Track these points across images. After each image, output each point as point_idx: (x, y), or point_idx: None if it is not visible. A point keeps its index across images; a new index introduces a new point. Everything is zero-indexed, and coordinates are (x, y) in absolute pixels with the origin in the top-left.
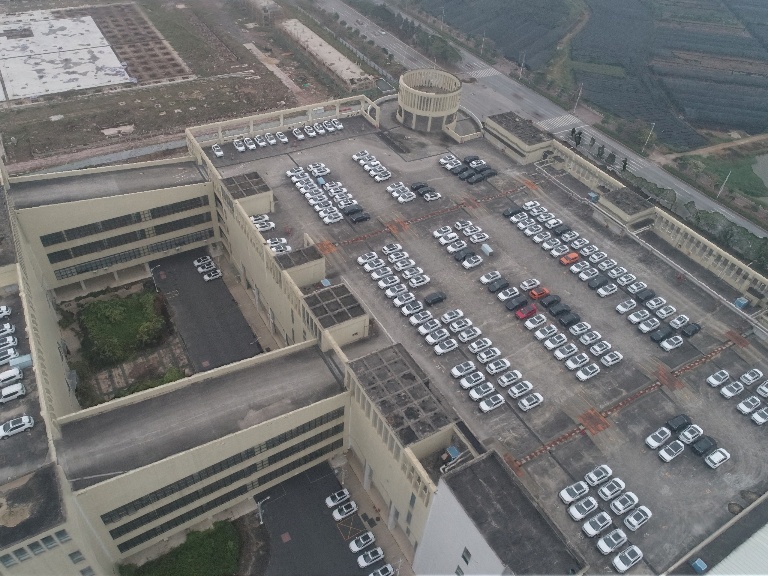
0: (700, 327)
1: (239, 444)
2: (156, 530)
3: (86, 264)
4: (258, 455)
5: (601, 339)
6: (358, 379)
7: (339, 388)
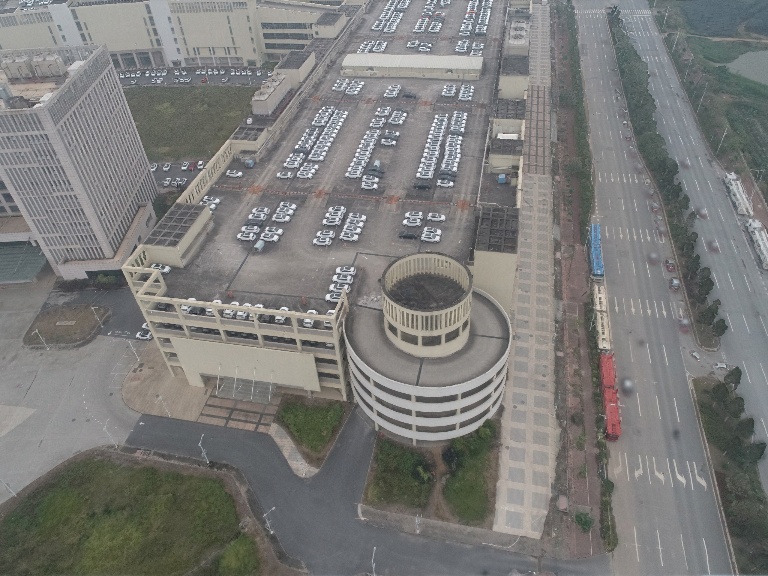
0: (485, 34)
1: (301, 18)
2: (276, 46)
3: (321, 2)
4: (308, 30)
5: (441, 29)
6: (339, 7)
7: None
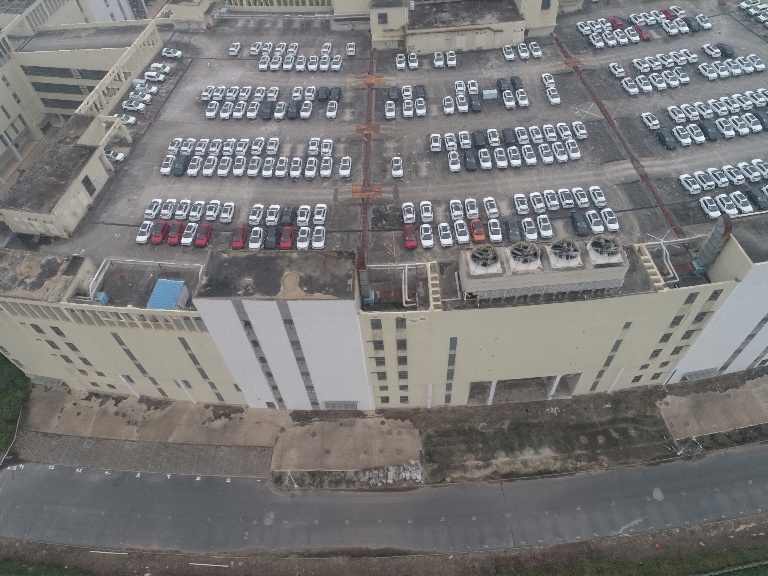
0: None
1: None
2: None
3: None
4: None
5: None
6: (29, 7)
7: (37, 35)
